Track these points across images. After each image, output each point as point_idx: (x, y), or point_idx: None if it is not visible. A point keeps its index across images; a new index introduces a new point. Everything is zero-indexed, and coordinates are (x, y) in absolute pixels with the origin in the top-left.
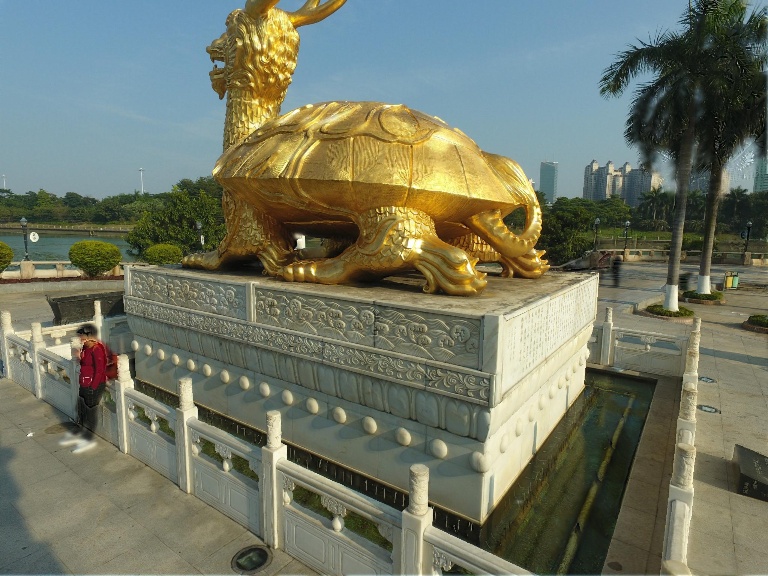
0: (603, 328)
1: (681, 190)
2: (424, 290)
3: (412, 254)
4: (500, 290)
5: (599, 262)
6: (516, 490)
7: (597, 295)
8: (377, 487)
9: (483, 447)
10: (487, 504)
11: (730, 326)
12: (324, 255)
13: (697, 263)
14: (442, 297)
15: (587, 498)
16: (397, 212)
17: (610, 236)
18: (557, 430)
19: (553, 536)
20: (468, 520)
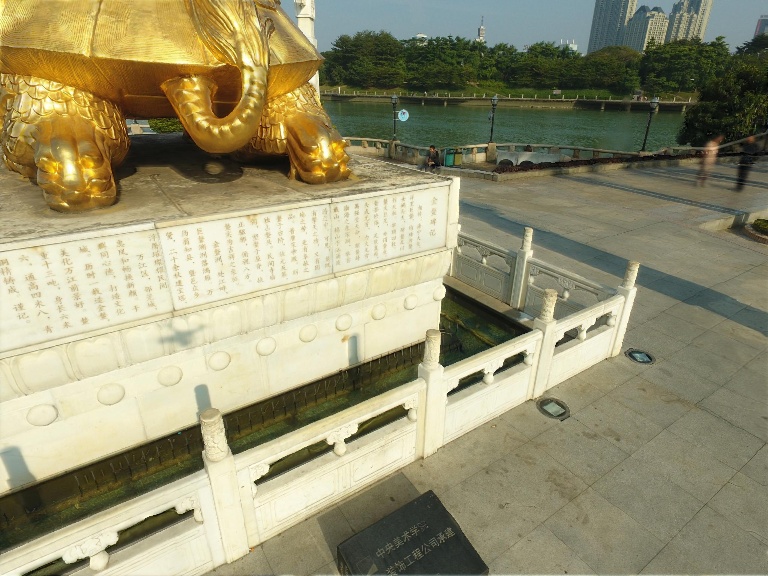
0: (517, 257)
1: None
2: None
3: (22, 145)
4: (163, 203)
5: None
6: None
7: (456, 212)
8: None
9: None
10: (5, 480)
11: None
12: None
13: None
14: (31, 210)
15: None
16: (6, 82)
17: None
18: (295, 392)
19: None
20: None
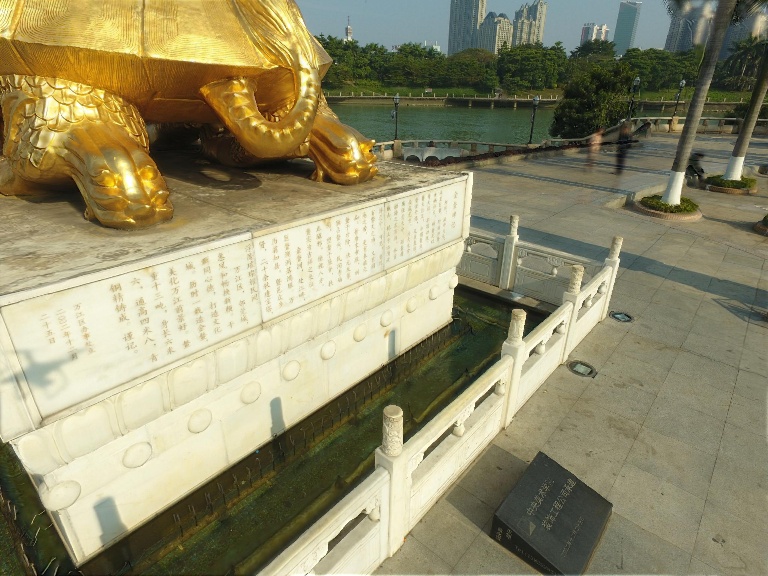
0: (505, 242)
1: (714, 38)
2: (85, 214)
3: (51, 157)
4: (223, 212)
5: (634, 133)
6: (212, 492)
7: (469, 204)
8: (1, 487)
9: (44, 480)
10: (98, 536)
11: (738, 226)
12: (154, 137)
13: (760, 135)
14: (81, 230)
15: (304, 510)
16: (22, 85)
17: (658, 100)
18: (350, 393)
19: (202, 575)
20: (69, 555)
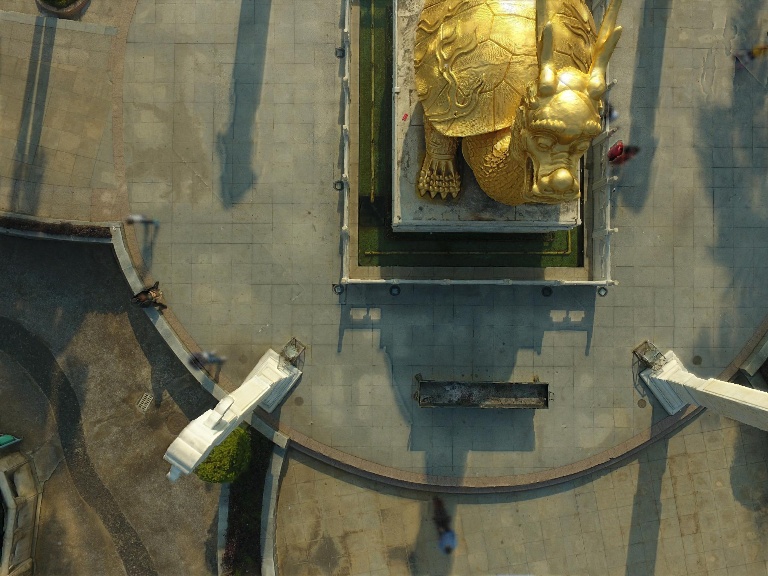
0: None
1: None
2: None
3: None
4: None
5: None
6: None
7: None
8: None
9: None
10: None
11: None
12: None
13: None
14: None
15: None
16: None
17: None
18: None
19: None
20: None
